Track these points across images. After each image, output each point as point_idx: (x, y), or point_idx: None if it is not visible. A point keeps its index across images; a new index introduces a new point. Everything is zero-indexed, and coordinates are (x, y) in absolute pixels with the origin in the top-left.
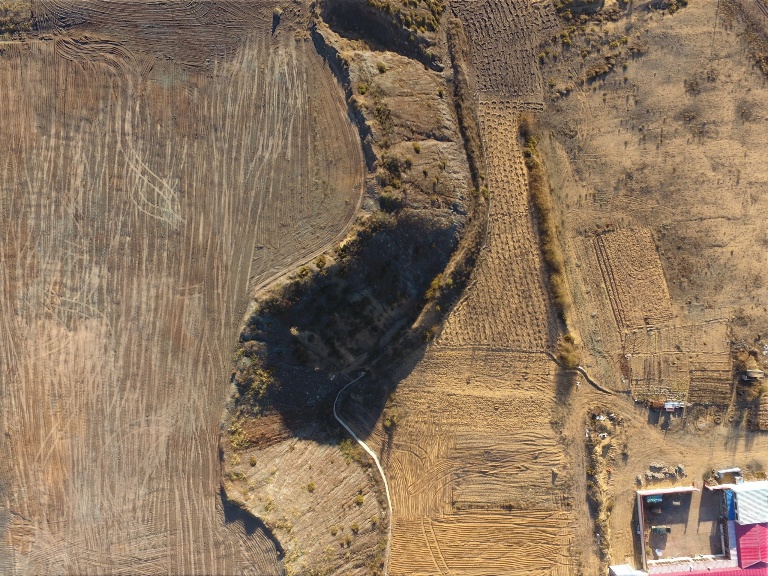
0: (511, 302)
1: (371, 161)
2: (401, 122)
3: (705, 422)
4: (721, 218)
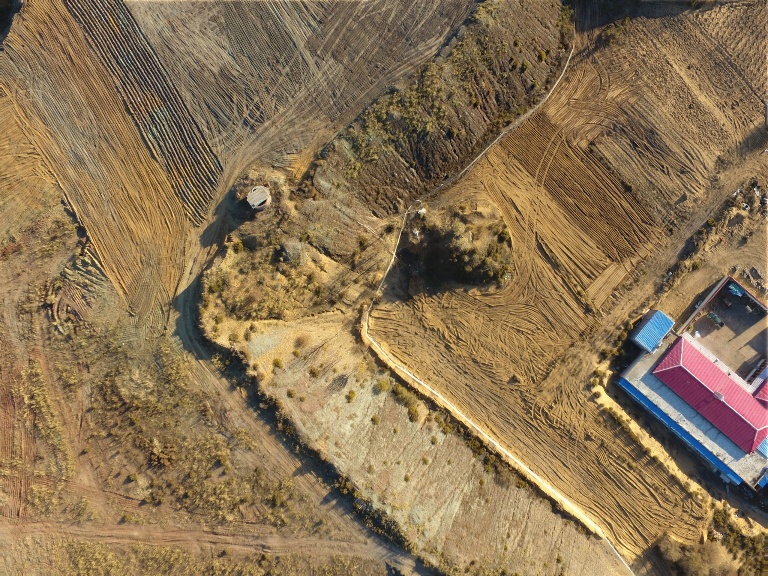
0: None
1: None
2: None
3: None
4: None
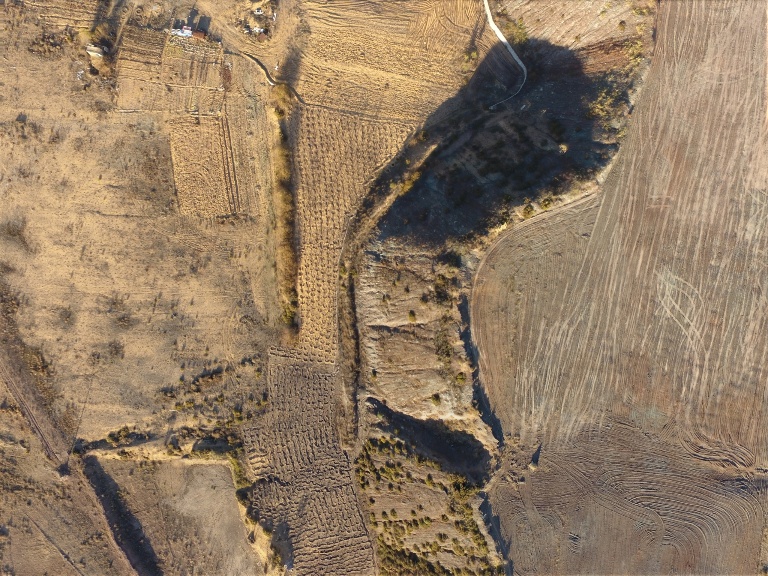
0: (332, 159)
1: (463, 305)
2: (425, 342)
3: (153, 11)
4: (106, 215)
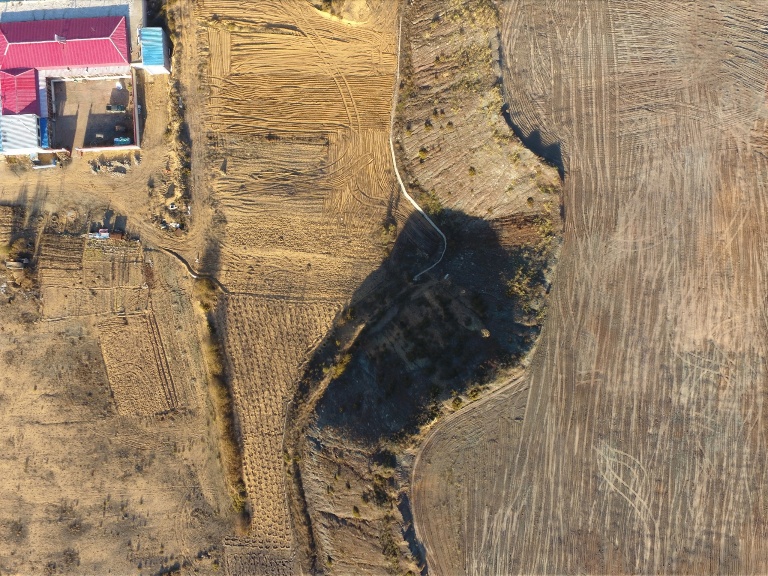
0: (263, 346)
1: (404, 504)
2: (372, 540)
3: (68, 217)
4: (46, 424)
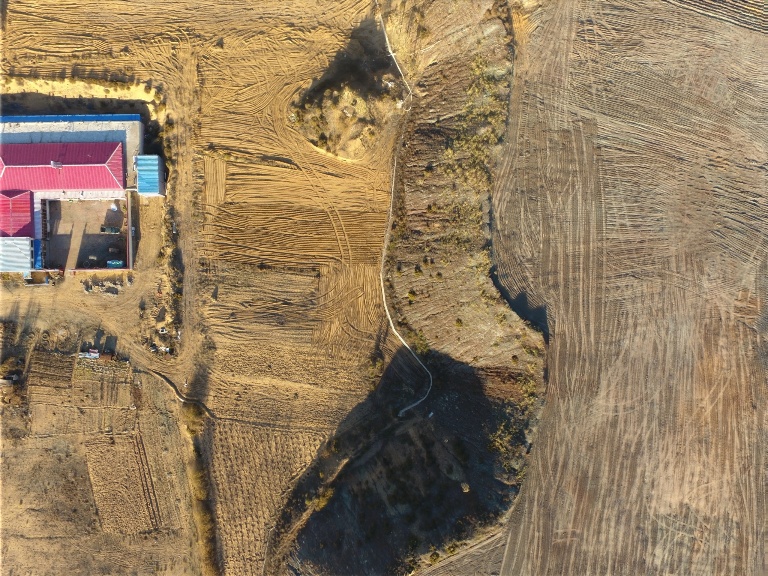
0: (248, 472)
1: None
2: None
3: (59, 335)
4: (30, 538)
